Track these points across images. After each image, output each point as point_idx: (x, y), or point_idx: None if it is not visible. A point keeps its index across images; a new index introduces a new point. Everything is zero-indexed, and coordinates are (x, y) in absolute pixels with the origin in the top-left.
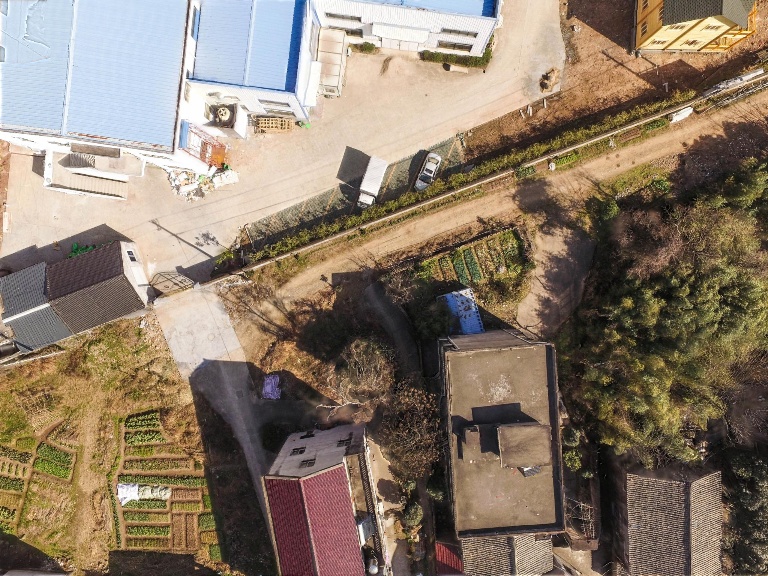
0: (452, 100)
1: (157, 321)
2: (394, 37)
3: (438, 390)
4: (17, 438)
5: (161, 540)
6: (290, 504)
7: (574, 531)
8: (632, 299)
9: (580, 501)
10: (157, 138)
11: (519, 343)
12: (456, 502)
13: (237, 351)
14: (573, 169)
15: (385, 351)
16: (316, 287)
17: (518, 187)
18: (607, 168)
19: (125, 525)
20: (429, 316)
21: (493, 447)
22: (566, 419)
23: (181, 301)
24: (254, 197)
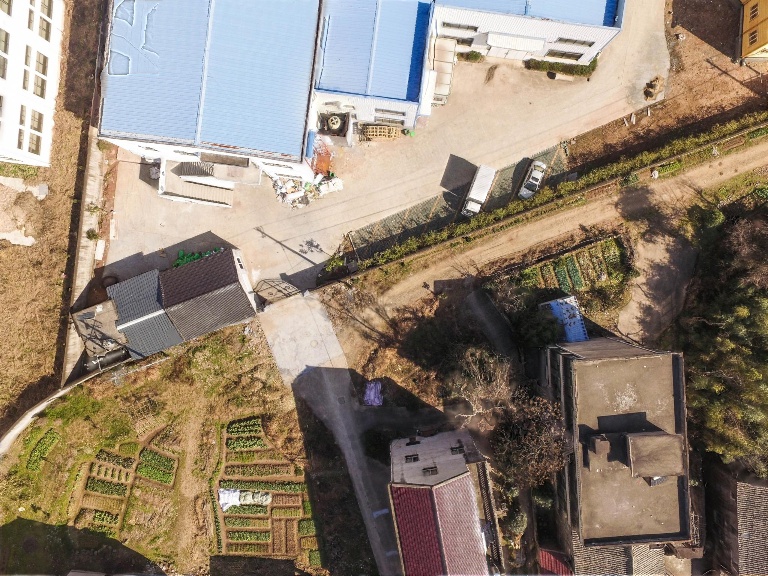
0: (556, 108)
1: (261, 328)
2: (509, 46)
3: (556, 398)
4: (120, 443)
5: (261, 545)
6: (419, 512)
7: None
8: (747, 308)
9: None
10: (287, 148)
11: (641, 352)
12: (581, 511)
13: (339, 358)
14: (676, 177)
15: (499, 359)
16: (418, 294)
17: (621, 195)
18: (710, 176)
19: (226, 530)
20: (537, 324)
21: (620, 456)
22: None
23: (284, 308)
24: (358, 205)
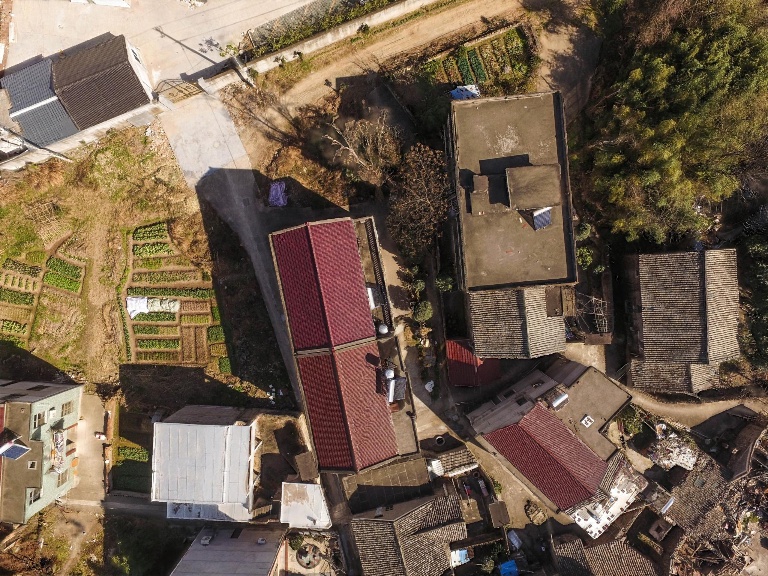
0: None
1: (163, 129)
2: None
3: None
4: (27, 252)
5: (171, 353)
6: (298, 255)
7: (587, 334)
8: (640, 69)
9: (592, 296)
10: None
11: None
12: (465, 256)
13: (243, 158)
14: None
15: (391, 130)
16: (320, 92)
17: None
18: None
19: (135, 339)
20: (434, 106)
21: (502, 198)
22: (576, 221)
23: (186, 109)
24: (256, 2)
